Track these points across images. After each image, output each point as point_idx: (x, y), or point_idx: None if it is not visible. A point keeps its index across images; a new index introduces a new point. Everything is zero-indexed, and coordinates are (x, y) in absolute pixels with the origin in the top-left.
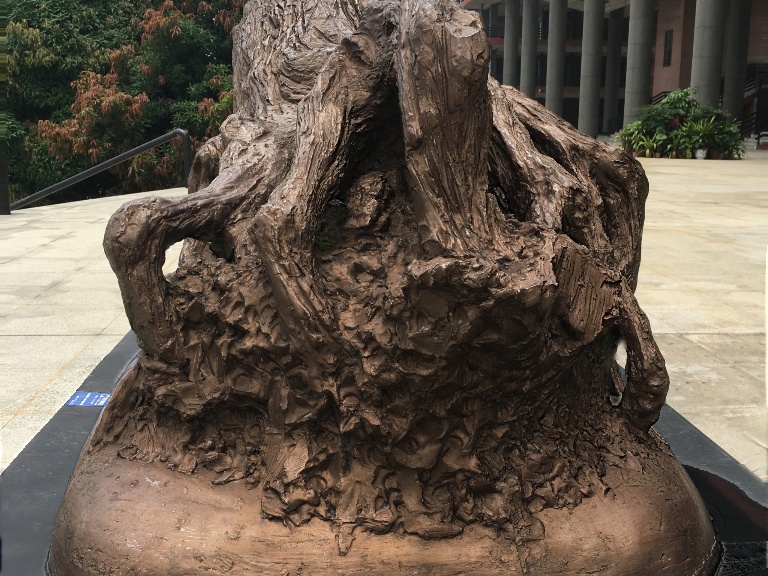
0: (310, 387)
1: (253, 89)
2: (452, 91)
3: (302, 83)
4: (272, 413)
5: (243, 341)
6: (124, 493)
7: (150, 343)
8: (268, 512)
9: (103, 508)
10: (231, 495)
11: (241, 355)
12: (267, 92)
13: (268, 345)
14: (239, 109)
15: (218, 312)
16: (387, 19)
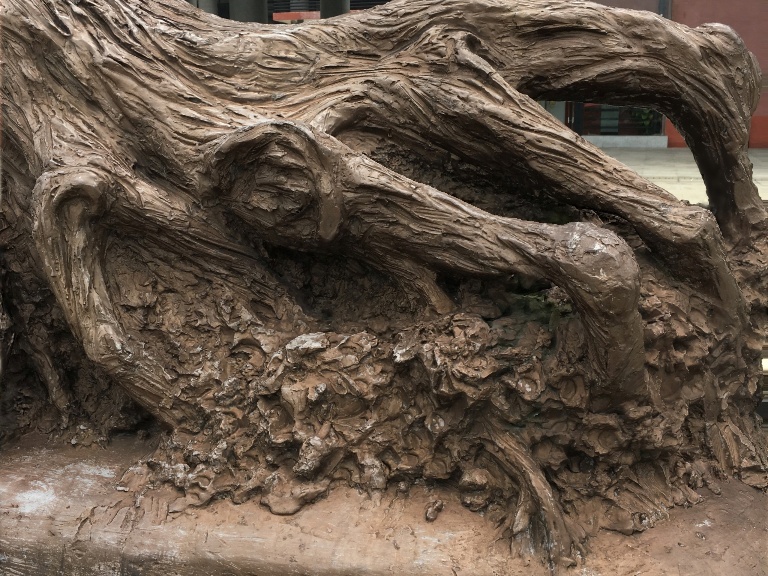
0: (735, 367)
1: (123, 81)
2: (757, 99)
3: (238, 77)
4: (706, 409)
5: (698, 348)
6: (714, 547)
7: (633, 390)
8: (764, 486)
9: (729, 569)
10: (736, 493)
11: (702, 362)
12: (181, 87)
13: (713, 343)
14: (31, 111)
15: (668, 330)
16: (571, 24)
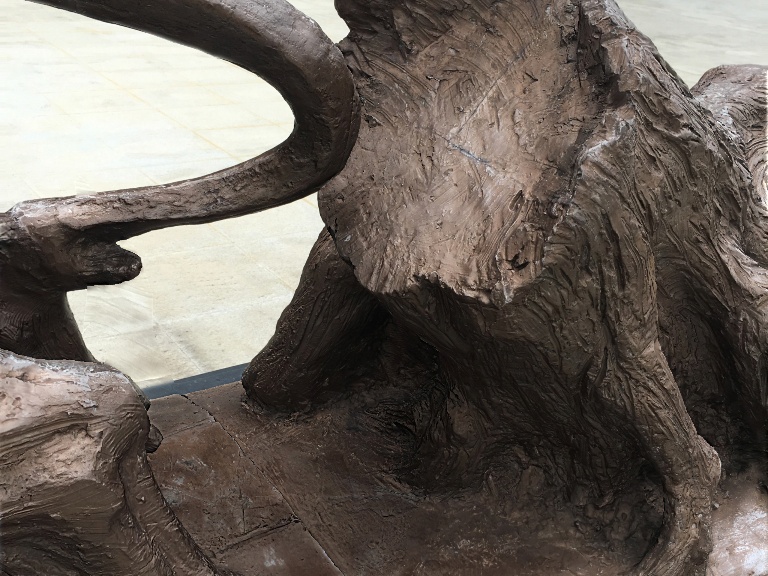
0: None
1: None
2: None
3: None
4: None
5: None
6: None
7: None
8: None
9: None
10: None
11: None
12: None
13: None
14: (718, 242)
15: None
16: None
